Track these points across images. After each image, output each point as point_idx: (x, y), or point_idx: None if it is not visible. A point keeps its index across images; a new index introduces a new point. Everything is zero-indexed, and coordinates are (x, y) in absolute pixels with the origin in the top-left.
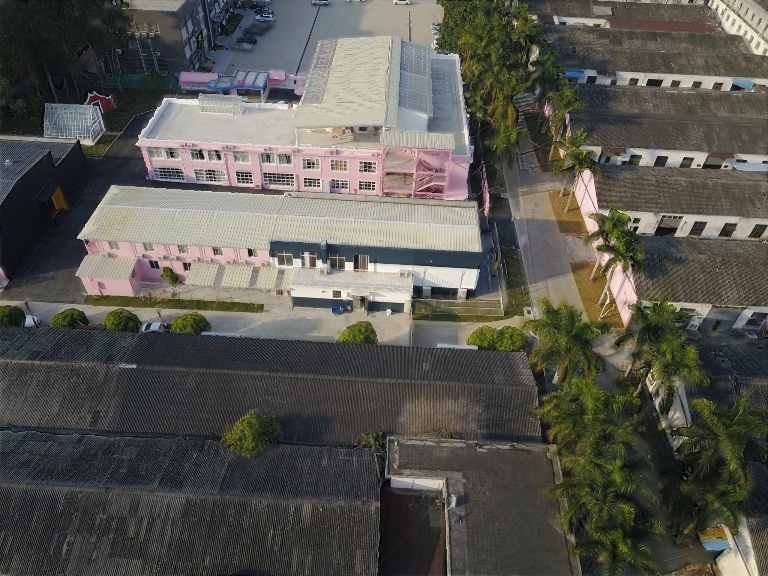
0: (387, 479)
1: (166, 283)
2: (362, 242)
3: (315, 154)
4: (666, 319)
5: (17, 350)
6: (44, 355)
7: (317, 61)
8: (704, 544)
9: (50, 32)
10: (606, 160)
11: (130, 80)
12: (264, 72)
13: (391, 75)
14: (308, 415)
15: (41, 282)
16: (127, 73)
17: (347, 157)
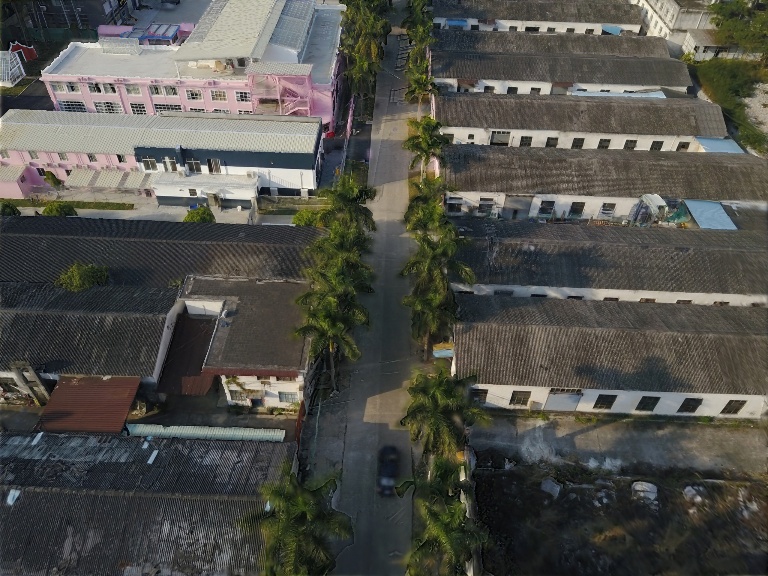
0: (184, 306)
1: (53, 189)
2: (214, 148)
3: (196, 85)
4: (430, 189)
5: None
6: None
7: (211, 9)
8: (434, 353)
9: None
10: None
11: (54, 34)
12: (175, 25)
13: (270, 18)
14: (136, 268)
15: None
16: None
17: (224, 87)
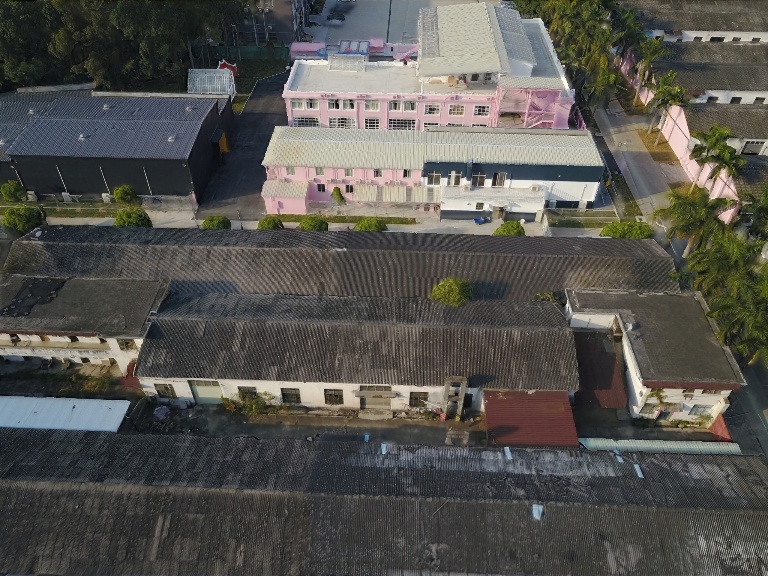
0: (568, 319)
1: (329, 204)
2: (500, 162)
3: (437, 100)
4: None
5: (245, 242)
6: (268, 244)
7: (423, 25)
8: None
9: (203, 3)
10: None
11: (246, 52)
12: (365, 41)
13: (494, 33)
14: (490, 282)
15: (225, 206)
16: None
17: (465, 102)
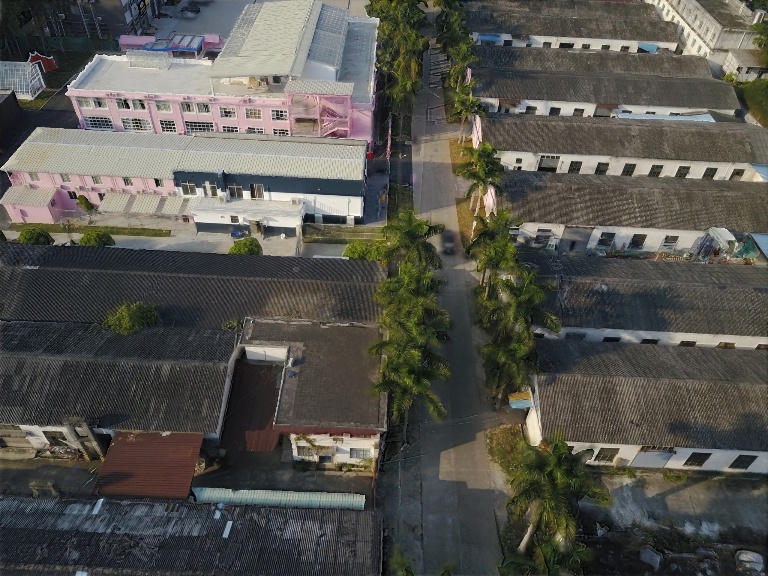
0: (243, 351)
1: (85, 213)
2: (257, 173)
3: (230, 103)
4: (498, 224)
5: None
6: None
7: (241, 22)
8: (511, 404)
9: None
10: (505, 112)
11: (73, 43)
12: (200, 36)
13: (305, 33)
14: (186, 306)
15: None
16: (71, 37)
17: (259, 105)
